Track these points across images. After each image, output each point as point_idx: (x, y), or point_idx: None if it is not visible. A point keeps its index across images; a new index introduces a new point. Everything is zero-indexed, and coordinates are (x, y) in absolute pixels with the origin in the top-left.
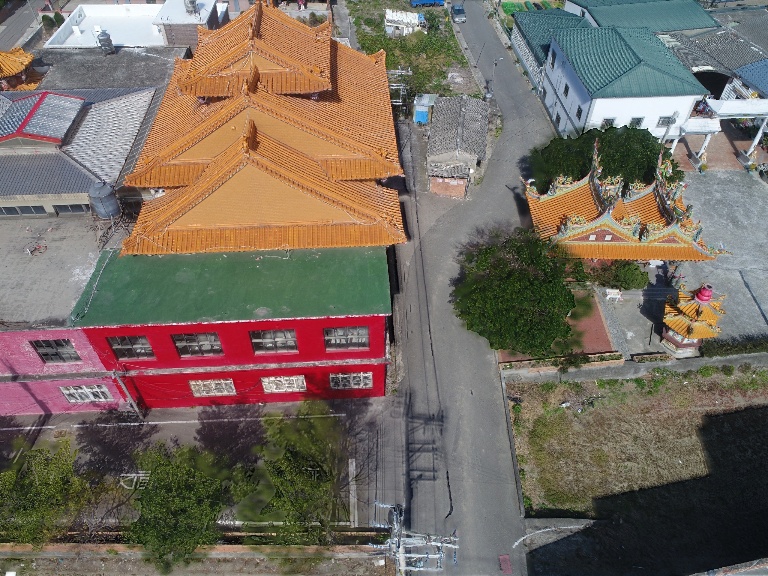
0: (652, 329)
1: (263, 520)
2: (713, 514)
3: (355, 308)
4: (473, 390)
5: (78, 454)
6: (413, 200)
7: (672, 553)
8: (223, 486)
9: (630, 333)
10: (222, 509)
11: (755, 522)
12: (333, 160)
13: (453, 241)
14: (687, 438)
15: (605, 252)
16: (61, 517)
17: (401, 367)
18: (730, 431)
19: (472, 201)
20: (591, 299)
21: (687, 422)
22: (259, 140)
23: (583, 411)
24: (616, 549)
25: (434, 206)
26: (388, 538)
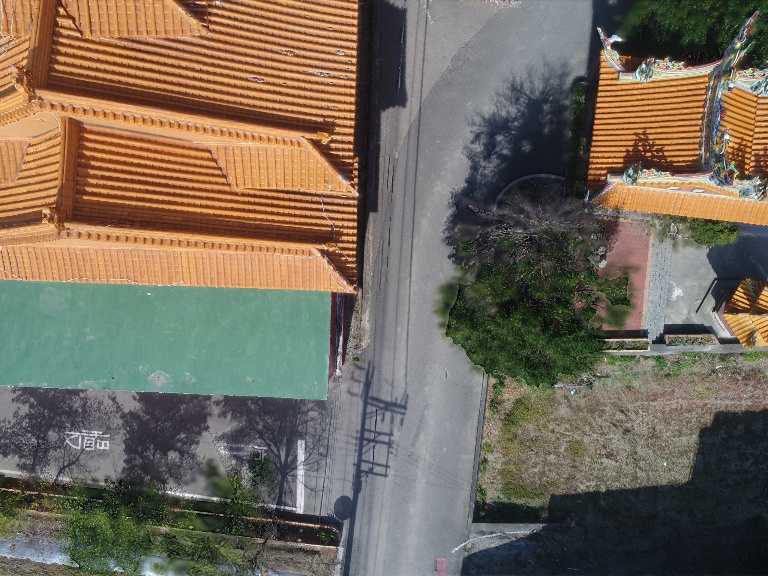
0: (710, 288)
1: (211, 495)
2: (673, 525)
3: (280, 386)
4: (448, 372)
5: (16, 404)
6: (423, 5)
7: (612, 559)
8: (169, 457)
9: (678, 290)
10: (170, 482)
11: (713, 538)
12: (236, 147)
13: (470, 109)
14: (686, 437)
15: (685, 206)
16: (4, 528)
17: (366, 331)
18: (741, 435)
19: (520, 8)
20: (644, 239)
21: (696, 418)
22: (89, 153)
23: (577, 392)
24: (557, 552)
25: (455, 21)
26: (330, 537)
